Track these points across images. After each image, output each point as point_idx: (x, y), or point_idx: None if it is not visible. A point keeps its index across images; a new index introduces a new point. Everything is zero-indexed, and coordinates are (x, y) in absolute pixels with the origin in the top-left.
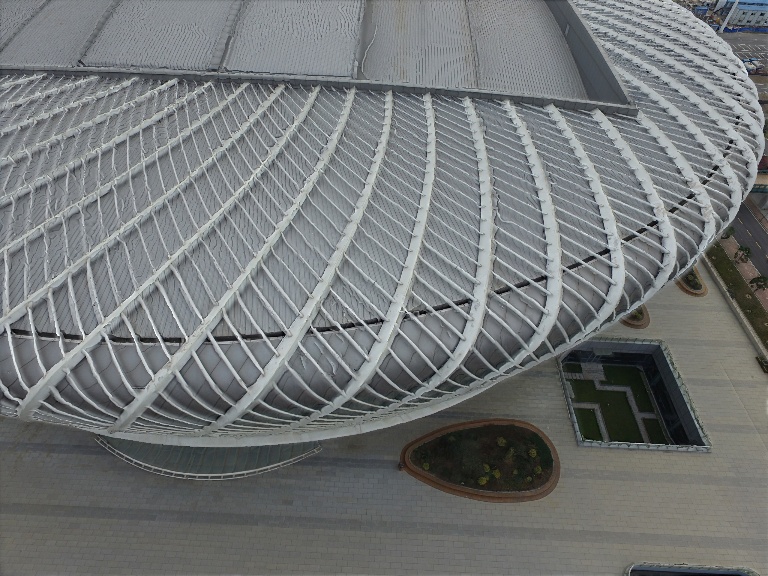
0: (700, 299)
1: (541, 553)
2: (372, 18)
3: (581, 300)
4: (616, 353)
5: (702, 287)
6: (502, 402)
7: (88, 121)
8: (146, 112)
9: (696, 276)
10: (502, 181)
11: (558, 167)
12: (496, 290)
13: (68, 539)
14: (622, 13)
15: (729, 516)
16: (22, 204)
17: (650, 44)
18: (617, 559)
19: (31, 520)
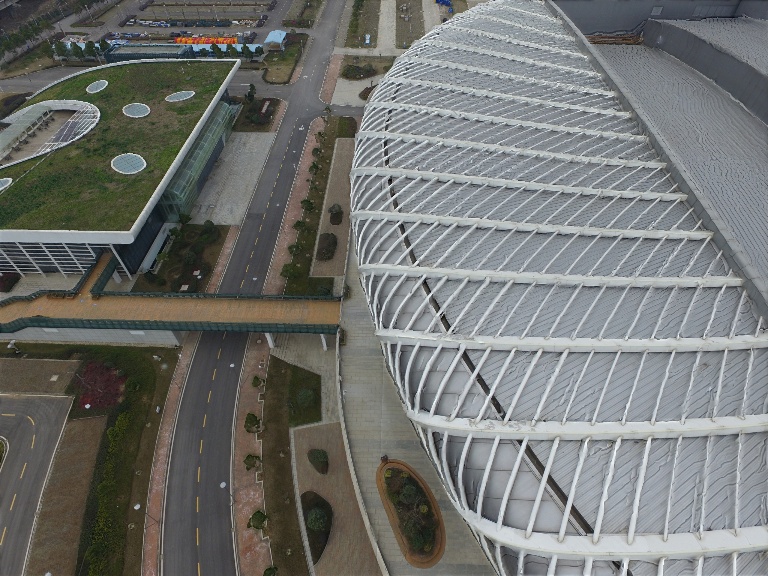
0: None
1: None
2: None
3: None
4: None
5: None
6: None
7: None
8: None
9: None
10: None
11: None
12: None
13: None
14: (529, 78)
15: None
16: None
17: None
18: None
19: None
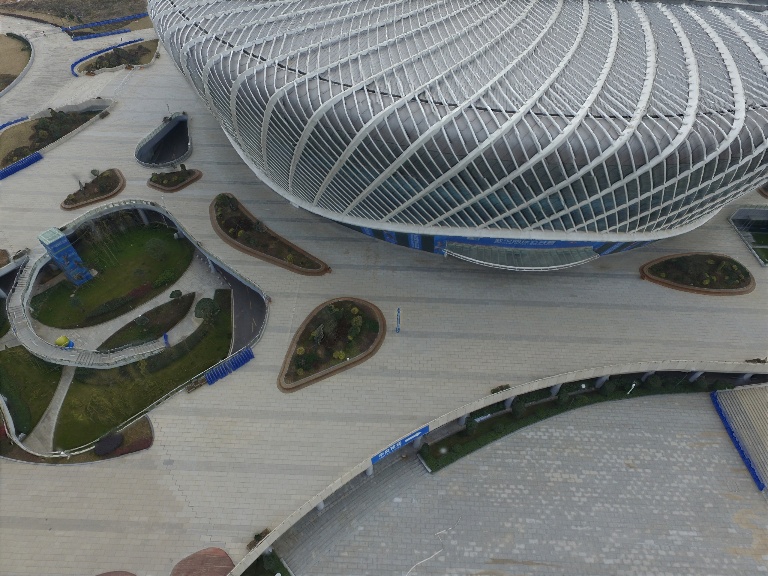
0: None
1: (759, 320)
2: None
3: None
4: (764, 221)
5: None
6: (698, 243)
7: (481, 17)
8: (514, 12)
9: None
10: (764, 47)
11: None
12: None
13: (436, 313)
14: None
15: None
16: (490, 55)
17: None
18: None
19: (405, 304)
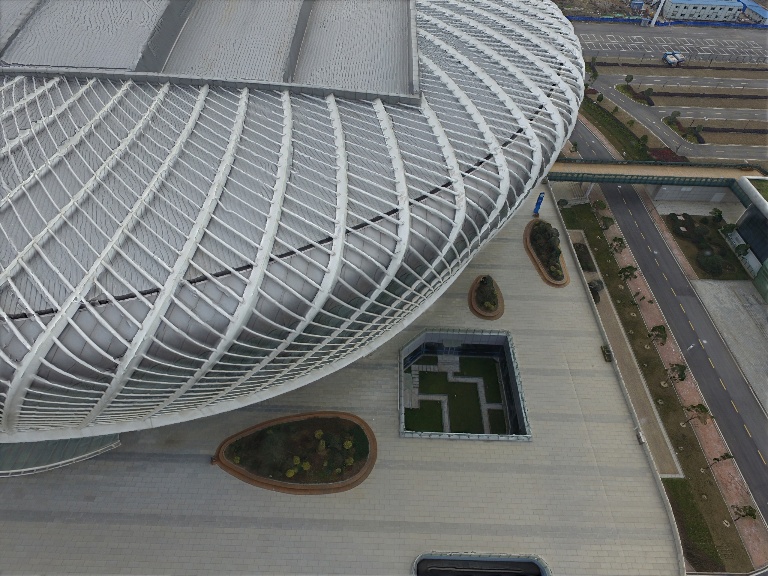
0: (560, 290)
1: (335, 544)
2: (183, 11)
3: (285, 288)
4: (468, 345)
5: (564, 278)
6: (334, 395)
7: None
8: None
9: (560, 267)
10: (240, 171)
11: (308, 156)
12: (192, 279)
13: None
14: (465, 5)
15: (534, 504)
16: None
17: (479, 35)
18: (410, 549)
19: None
